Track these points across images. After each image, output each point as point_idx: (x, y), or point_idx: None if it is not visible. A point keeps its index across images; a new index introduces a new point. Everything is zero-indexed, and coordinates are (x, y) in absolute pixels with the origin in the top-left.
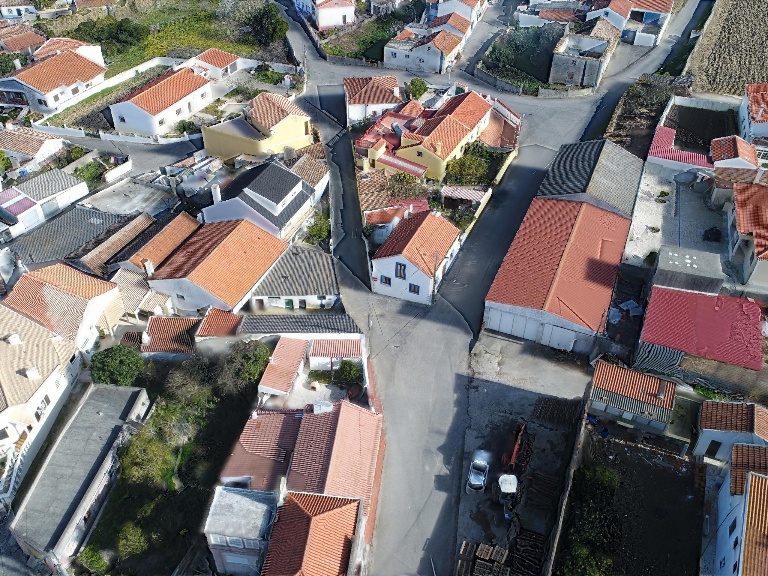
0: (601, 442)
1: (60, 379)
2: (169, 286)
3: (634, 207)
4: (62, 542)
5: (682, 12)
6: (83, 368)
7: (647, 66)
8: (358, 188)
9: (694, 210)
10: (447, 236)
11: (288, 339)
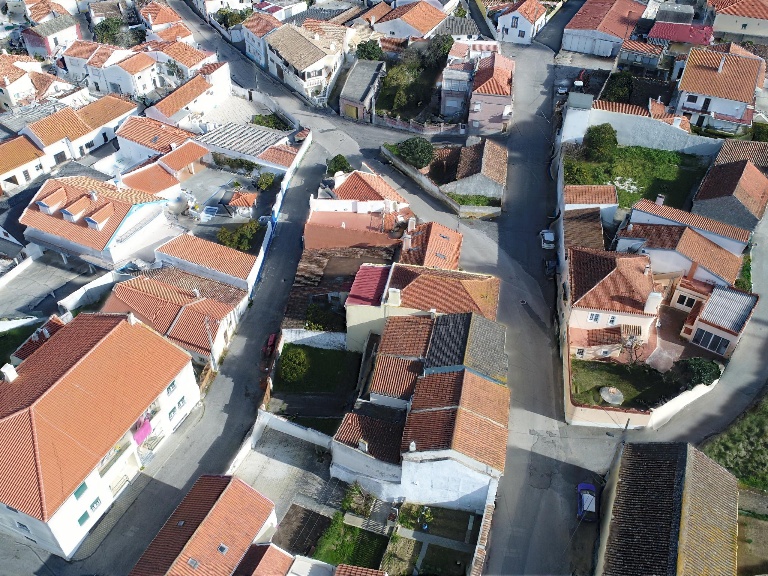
0: None
1: (339, 59)
2: (387, 26)
3: (649, 1)
4: (366, 100)
5: None
6: (344, 62)
7: None
8: (480, 0)
9: None
10: (540, 10)
11: (459, 43)
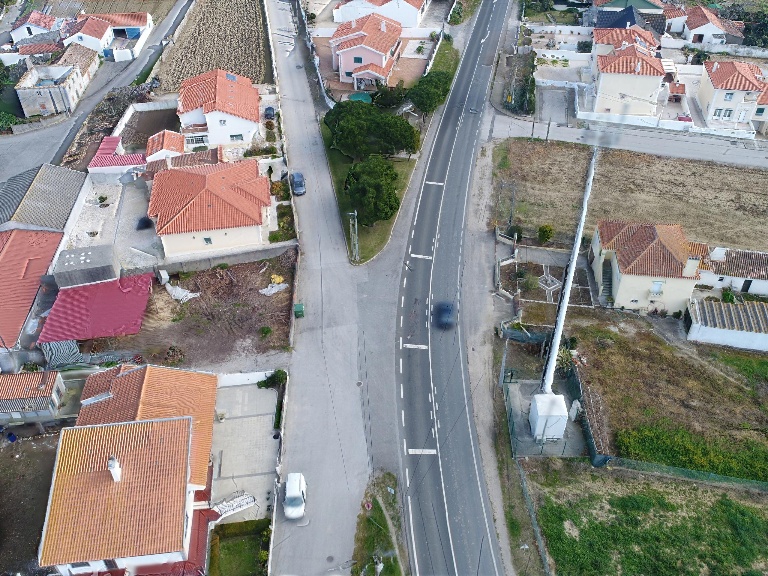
0: (10, 446)
1: None
2: None
3: (67, 220)
4: None
5: (164, 21)
6: None
7: (124, 80)
8: None
9: (134, 205)
10: None
11: None
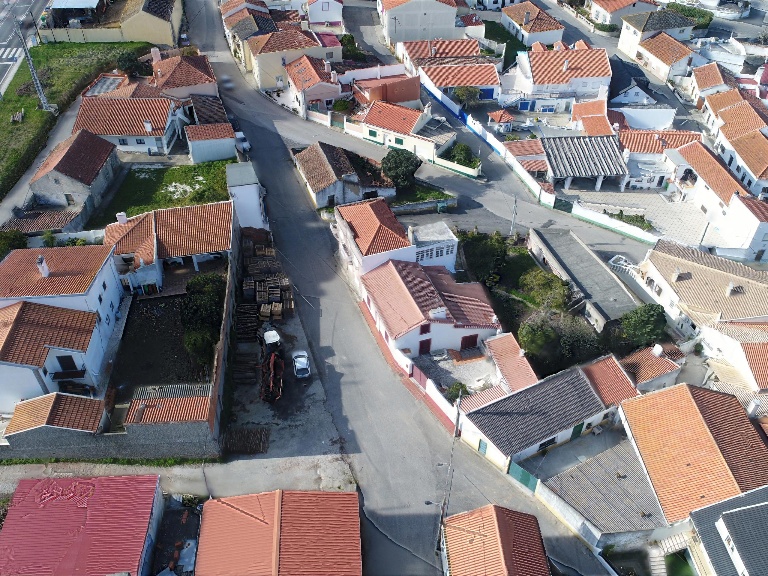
0: None
1: None
2: None
3: None
4: None
5: None
6: None
7: None
8: None
9: None
10: None
11: None
